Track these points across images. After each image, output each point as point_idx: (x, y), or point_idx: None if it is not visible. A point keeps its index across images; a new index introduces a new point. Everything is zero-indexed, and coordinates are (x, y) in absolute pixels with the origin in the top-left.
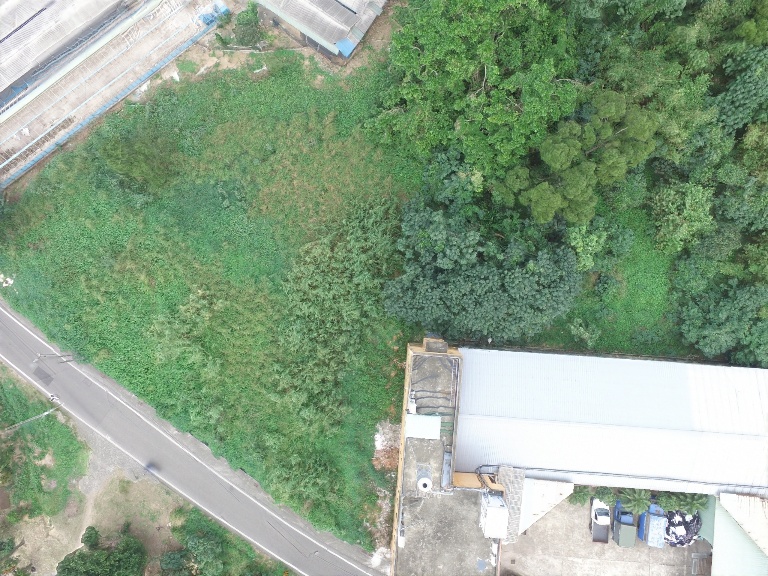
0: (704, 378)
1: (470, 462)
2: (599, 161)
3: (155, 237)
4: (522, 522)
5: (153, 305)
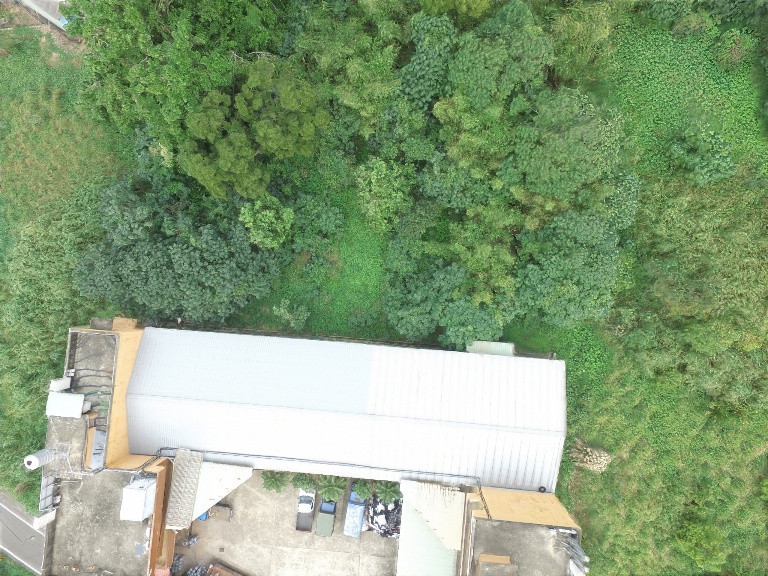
0: (389, 360)
1: (150, 444)
2: (256, 133)
3: None
4: (197, 507)
5: None
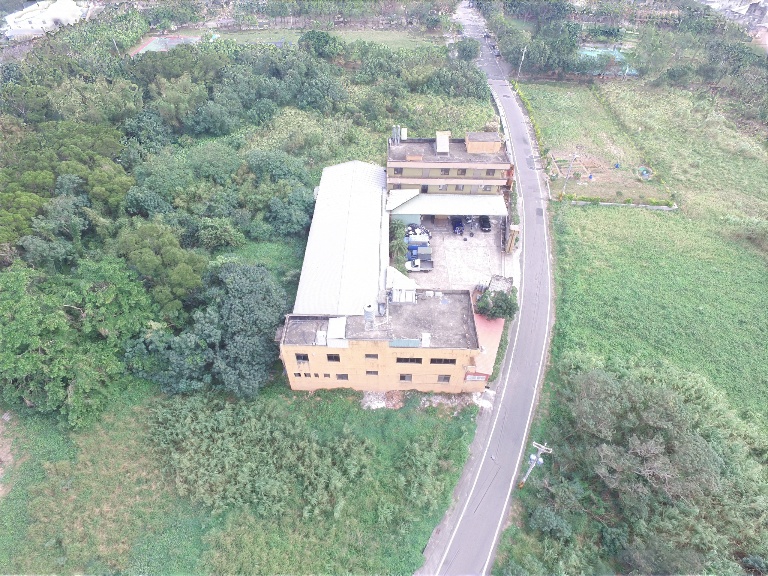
0: (320, 217)
1: None
2: None
3: None
4: None
5: None
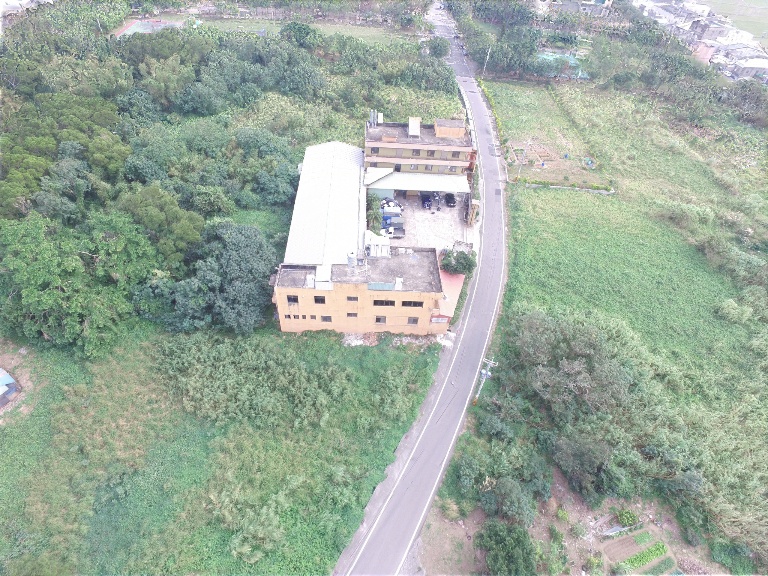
0: (304, 189)
1: None
2: None
3: (136, 574)
4: None
5: (220, 571)
